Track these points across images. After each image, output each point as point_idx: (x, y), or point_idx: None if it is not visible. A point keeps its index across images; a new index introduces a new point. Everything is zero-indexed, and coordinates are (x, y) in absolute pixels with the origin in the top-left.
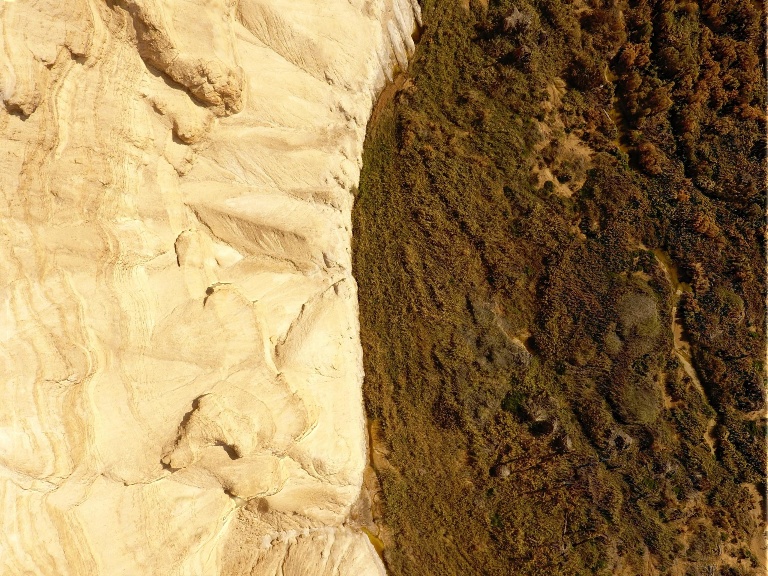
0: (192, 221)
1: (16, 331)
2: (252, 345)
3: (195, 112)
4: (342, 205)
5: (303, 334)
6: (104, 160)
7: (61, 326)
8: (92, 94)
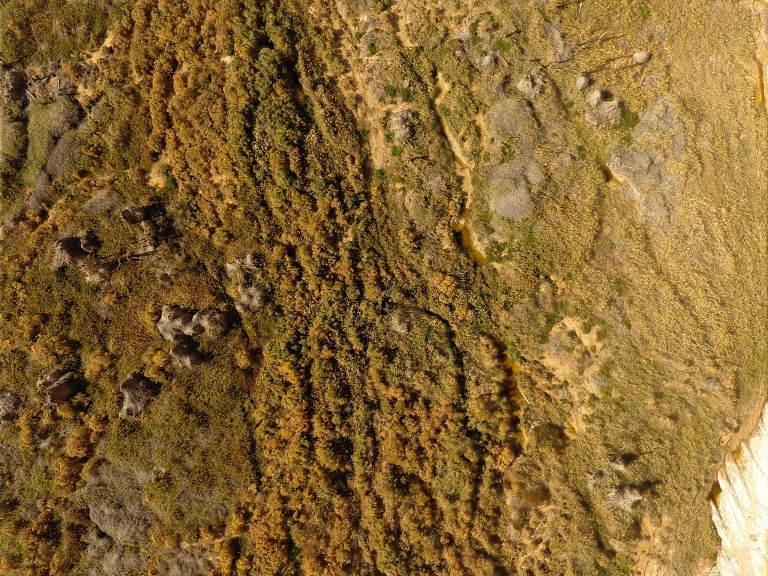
0: None
1: None
2: None
3: None
4: None
5: None
6: None
7: None
8: None
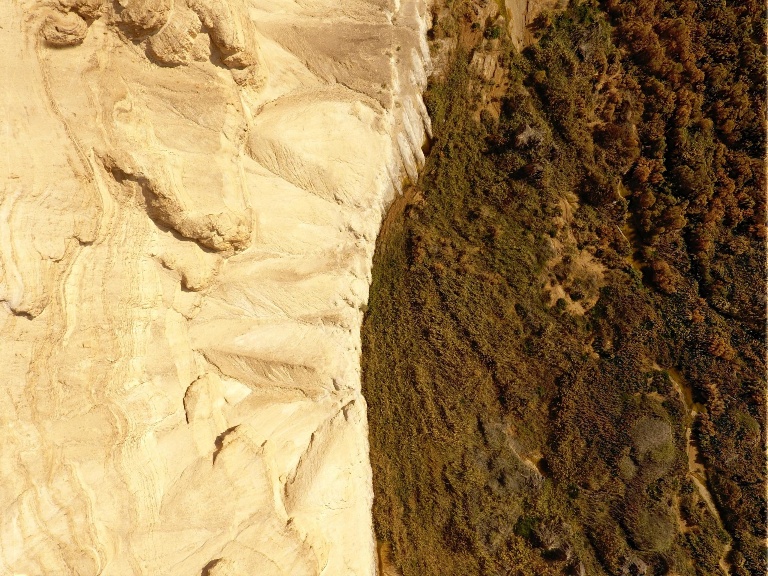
0: (200, 363)
1: (23, 550)
2: (262, 497)
3: (204, 261)
4: (351, 324)
5: (313, 470)
6: (112, 336)
7: (69, 532)
8: (100, 271)
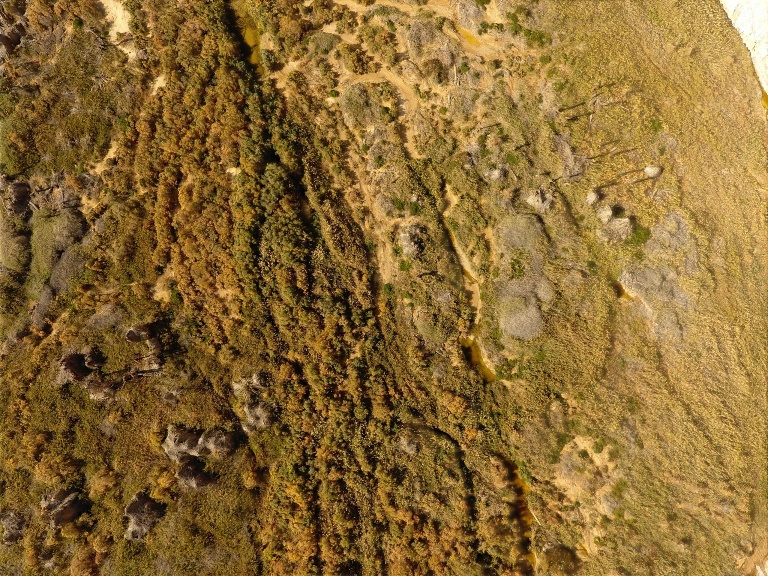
0: None
1: None
2: None
3: None
4: None
5: None
6: None
7: None
8: None
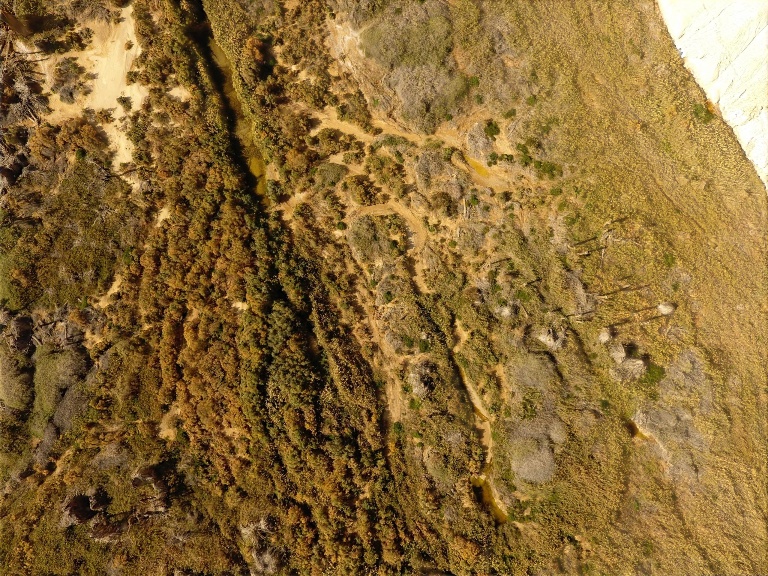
0: None
1: None
2: None
3: None
4: None
5: None
6: None
7: None
8: None
